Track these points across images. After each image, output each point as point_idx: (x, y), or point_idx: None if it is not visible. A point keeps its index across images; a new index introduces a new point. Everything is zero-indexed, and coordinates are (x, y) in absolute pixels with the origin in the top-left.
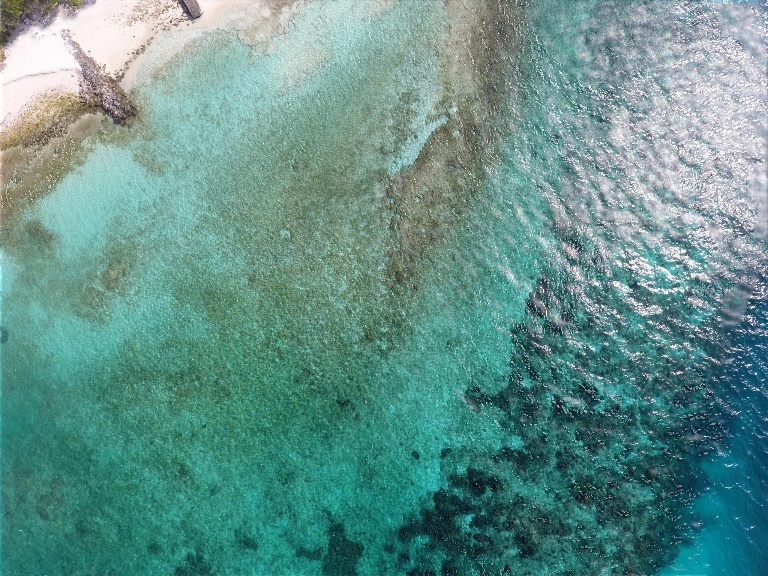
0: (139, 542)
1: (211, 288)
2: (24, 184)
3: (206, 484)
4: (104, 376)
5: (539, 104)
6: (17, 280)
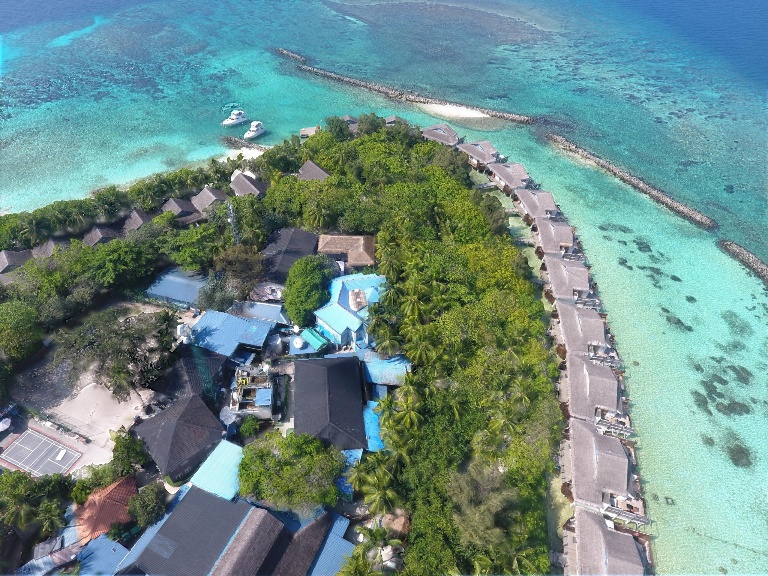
0: None
1: None
2: None
3: None
4: None
5: None
6: None
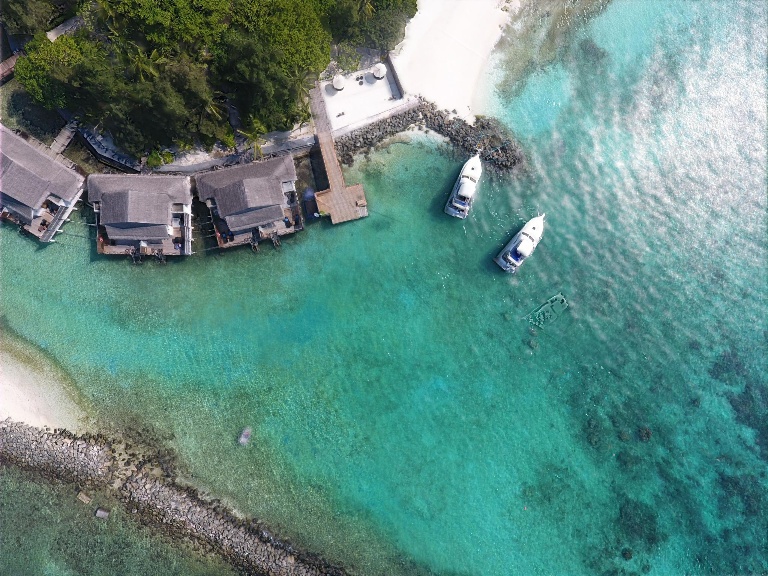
0: (682, 339)
1: (742, 106)
2: (580, 4)
3: (739, 288)
4: (649, 186)
5: None
6: (573, 95)
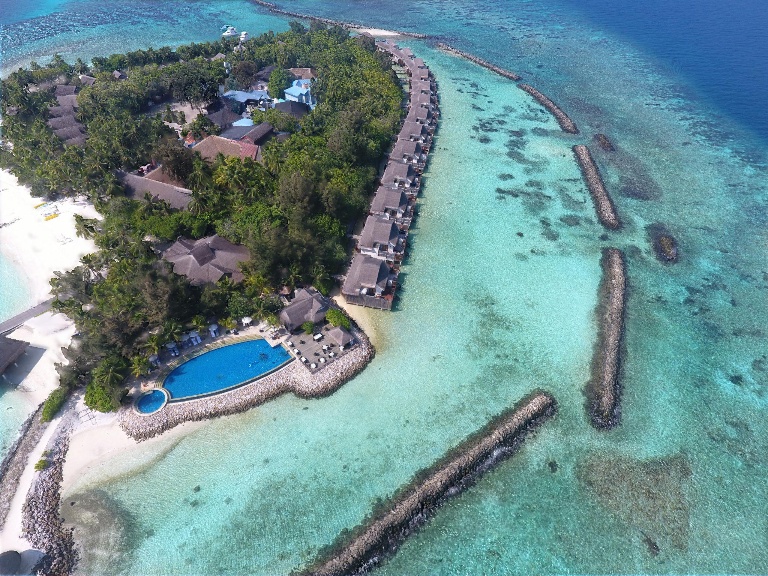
0: None
1: None
2: None
3: None
4: None
5: (2, 57)
6: None
